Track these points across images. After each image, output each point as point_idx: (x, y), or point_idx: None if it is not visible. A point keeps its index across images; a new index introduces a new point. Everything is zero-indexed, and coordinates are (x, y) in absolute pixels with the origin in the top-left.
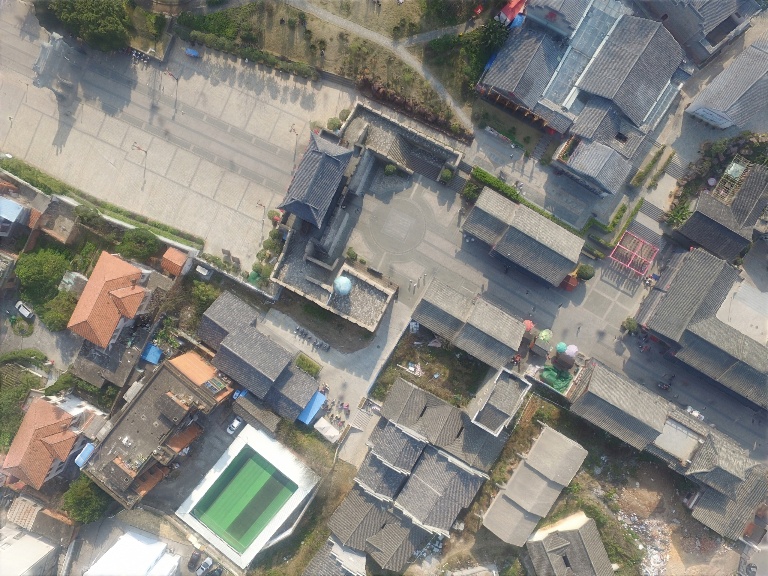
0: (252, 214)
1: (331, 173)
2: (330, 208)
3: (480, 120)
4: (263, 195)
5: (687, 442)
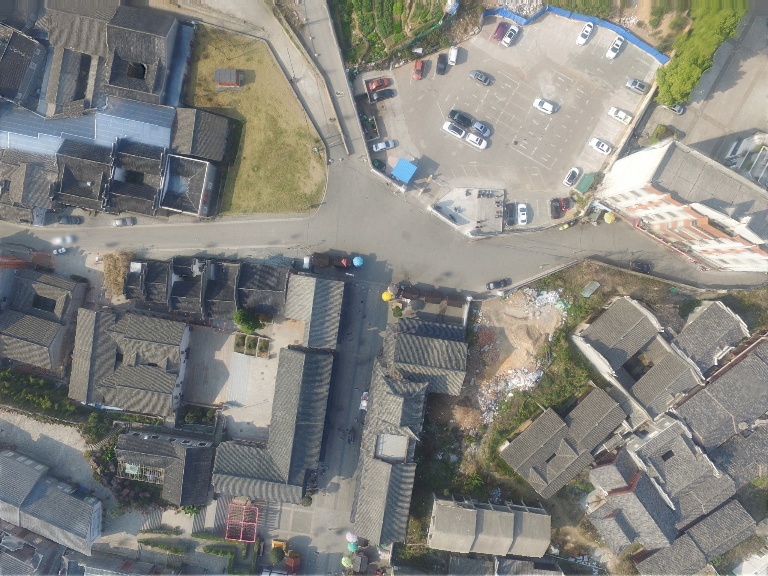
0: None
1: None
2: None
3: None
4: None
5: None
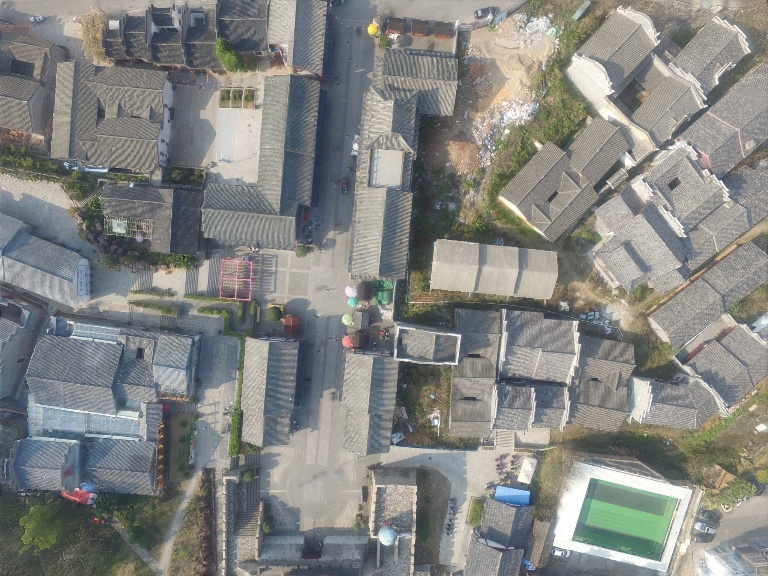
0: None
1: None
2: (325, 570)
3: (187, 471)
4: None
5: (384, 155)
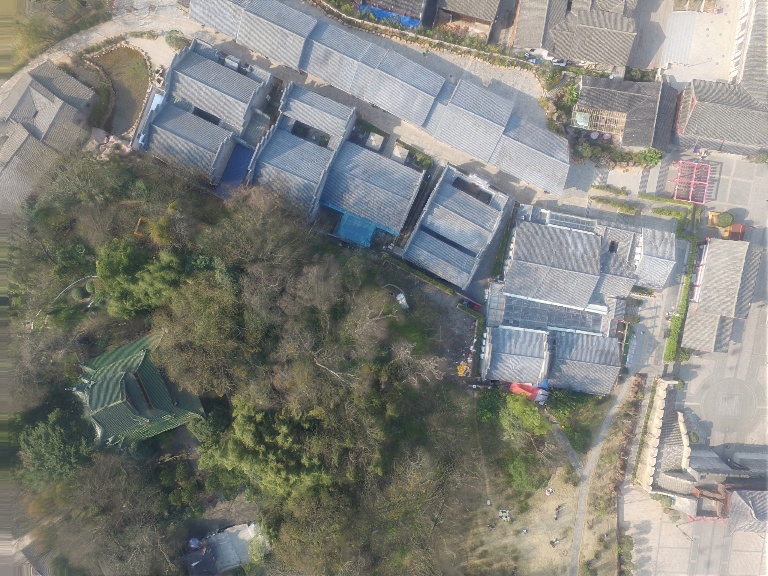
0: (761, 538)
1: (763, 504)
2: (760, 481)
3: None
4: (741, 535)
5: None
